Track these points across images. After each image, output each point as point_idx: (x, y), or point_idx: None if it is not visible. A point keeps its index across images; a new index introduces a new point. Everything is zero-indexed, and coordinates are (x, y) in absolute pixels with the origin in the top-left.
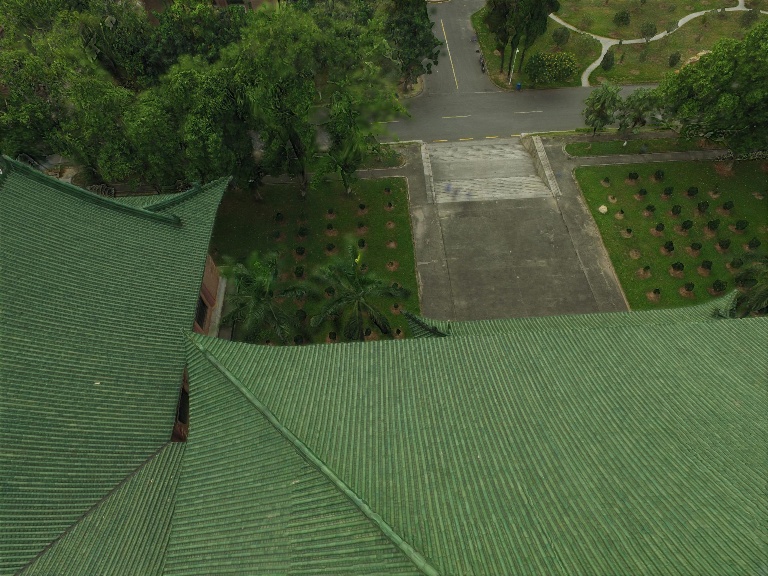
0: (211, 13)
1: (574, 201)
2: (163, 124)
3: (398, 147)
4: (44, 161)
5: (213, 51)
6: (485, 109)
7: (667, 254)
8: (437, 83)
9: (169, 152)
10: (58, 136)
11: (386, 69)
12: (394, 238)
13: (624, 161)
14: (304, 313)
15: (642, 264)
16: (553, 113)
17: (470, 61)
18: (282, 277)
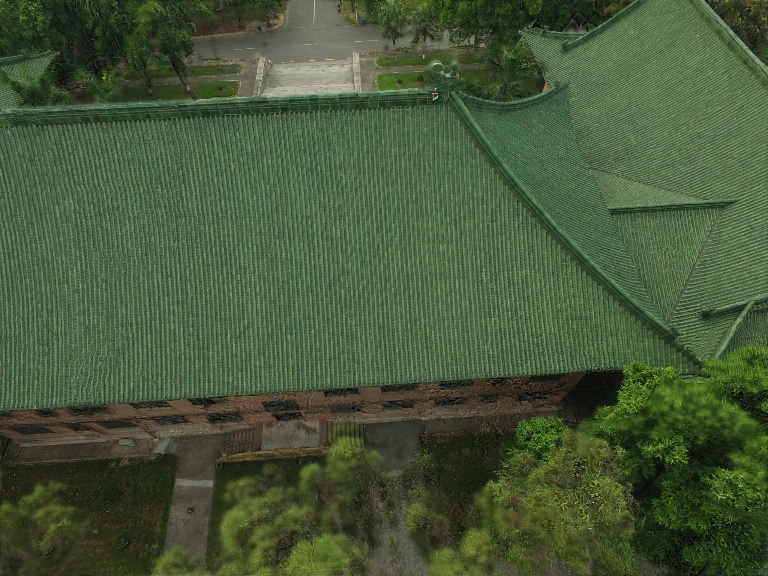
0: None
1: None
2: (7, 12)
3: (240, 60)
4: None
5: None
6: (331, 39)
7: None
8: (298, 20)
9: (15, 37)
10: None
11: (240, 1)
12: None
13: (420, 70)
14: None
15: None
16: (387, 41)
17: (331, 4)
18: None
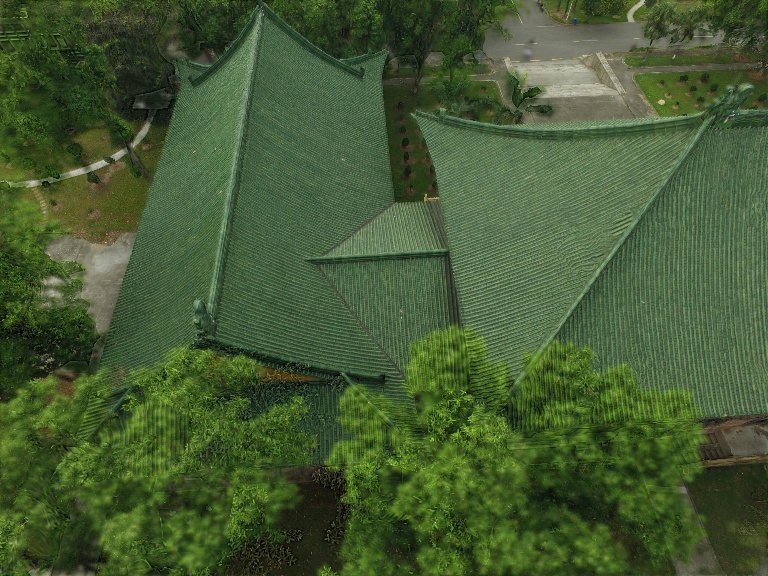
0: None
1: (637, 97)
2: (334, 10)
3: (485, 60)
4: (220, 50)
5: None
6: (548, 38)
7: None
8: (503, 19)
9: (334, 35)
10: (246, 22)
11: None
12: None
13: (674, 70)
14: None
15: None
16: (606, 41)
17: (529, 3)
18: (410, 147)
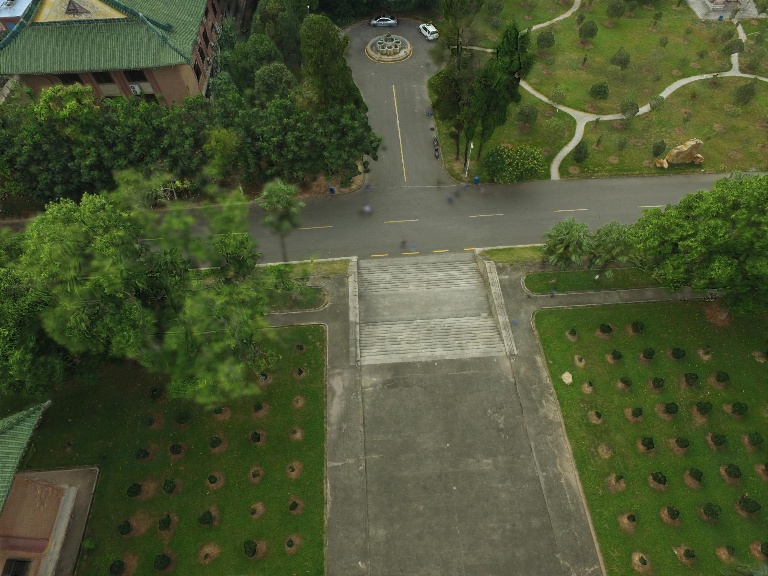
0: (90, 110)
1: (532, 363)
2: None
3: (321, 278)
4: None
5: (92, 157)
6: (435, 210)
7: (645, 451)
8: (382, 172)
9: None
10: None
11: (313, 170)
12: (301, 424)
13: (595, 301)
14: (165, 561)
15: (614, 467)
16: (515, 217)
17: (422, 142)
18: (149, 488)
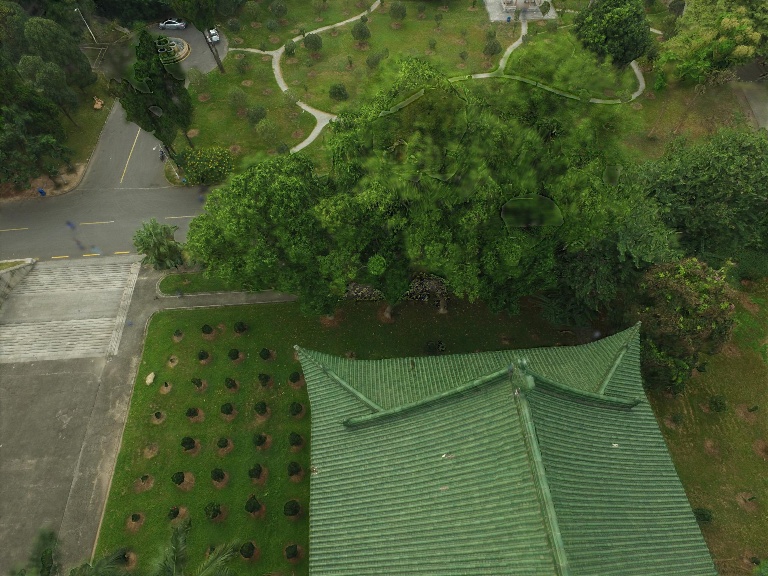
0: None
1: (125, 364)
2: None
3: None
4: None
5: None
6: (135, 212)
7: (190, 451)
8: (102, 174)
9: None
10: None
11: None
12: None
13: (220, 302)
14: None
15: (150, 468)
16: None
17: (156, 144)
18: None
